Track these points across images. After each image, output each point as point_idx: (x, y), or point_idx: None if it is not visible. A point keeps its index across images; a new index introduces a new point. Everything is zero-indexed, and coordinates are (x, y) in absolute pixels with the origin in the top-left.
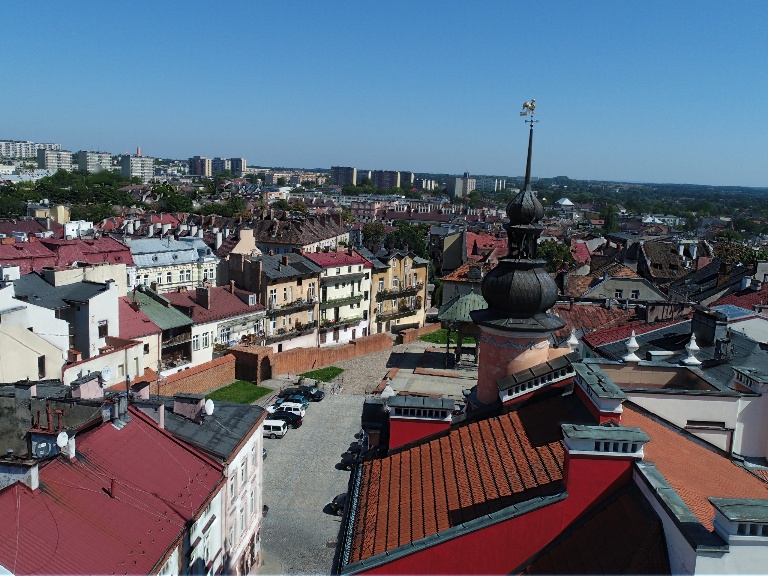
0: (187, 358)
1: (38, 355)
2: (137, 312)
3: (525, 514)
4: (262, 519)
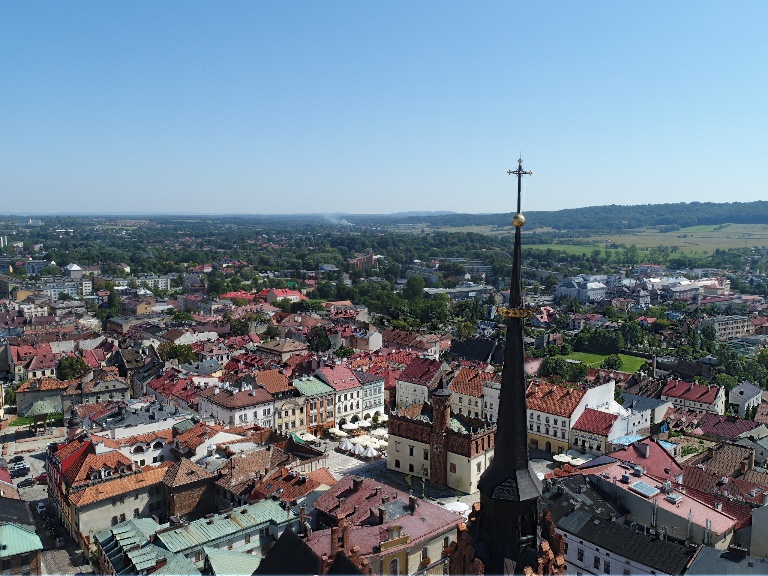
0: None
1: None
2: None
3: (81, 449)
4: None
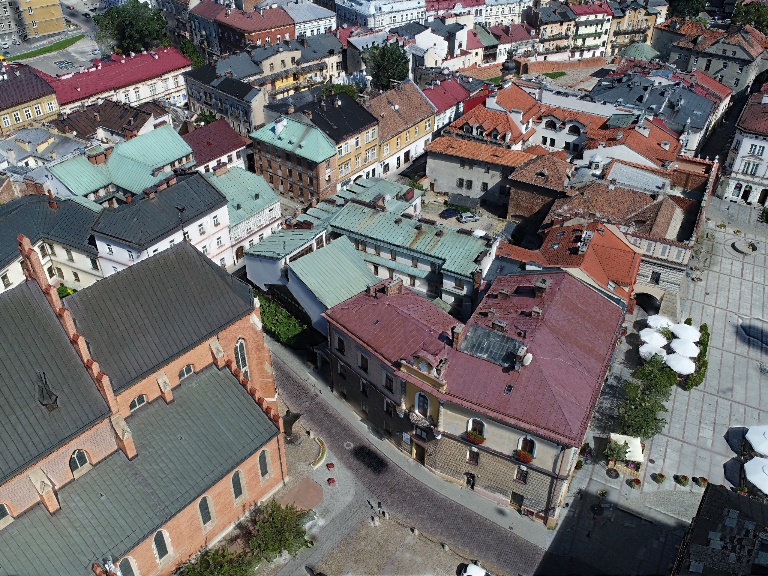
0: (495, 59)
1: (436, 60)
2: (476, 37)
3: None
4: None
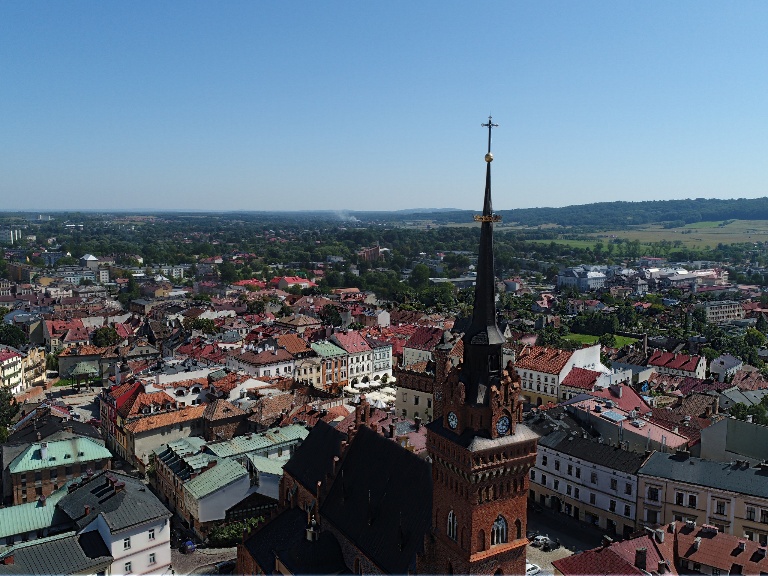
0: None
1: None
2: None
3: (132, 389)
4: None
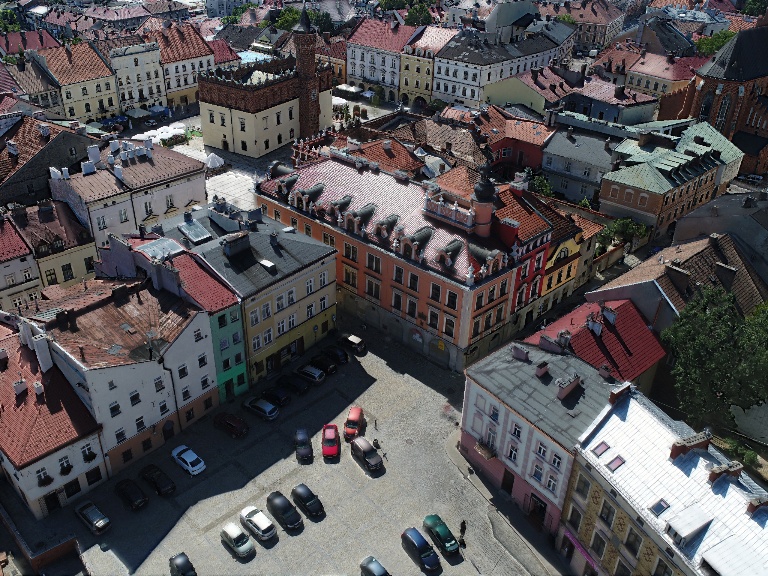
0: None
1: None
2: None
3: None
4: (427, 490)
